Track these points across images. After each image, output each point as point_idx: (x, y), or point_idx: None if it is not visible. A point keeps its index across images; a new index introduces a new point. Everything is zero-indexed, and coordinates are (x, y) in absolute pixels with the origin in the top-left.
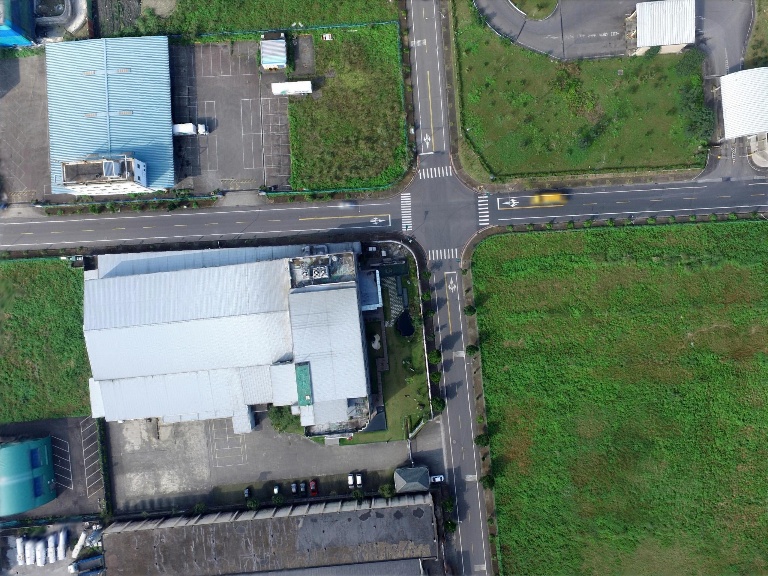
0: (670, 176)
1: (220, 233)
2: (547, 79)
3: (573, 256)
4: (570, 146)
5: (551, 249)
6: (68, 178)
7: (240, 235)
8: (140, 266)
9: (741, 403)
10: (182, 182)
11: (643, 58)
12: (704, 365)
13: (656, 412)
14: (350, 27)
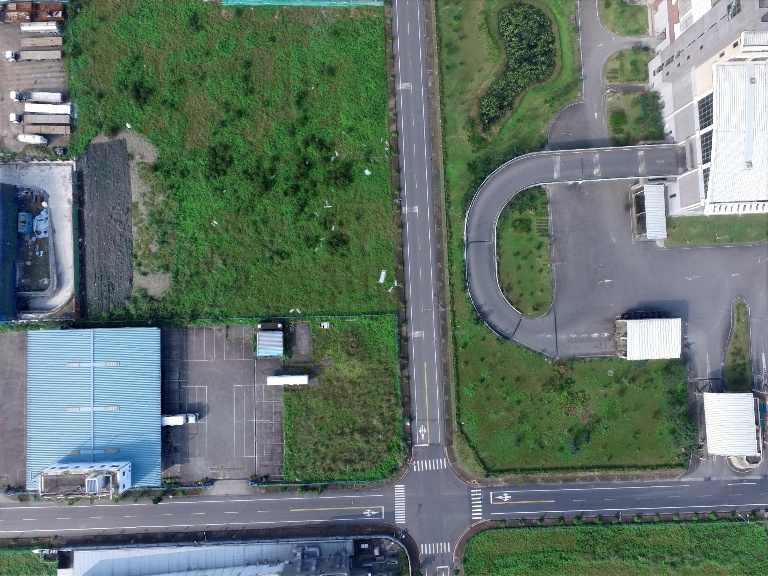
0: (655, 475)
1: (207, 523)
2: (541, 377)
3: (563, 553)
4: (562, 443)
5: (542, 545)
6: (46, 489)
7: (228, 526)
8: (120, 566)
9: None
10: (169, 470)
11: (632, 363)
12: None
13: None
14: (349, 316)
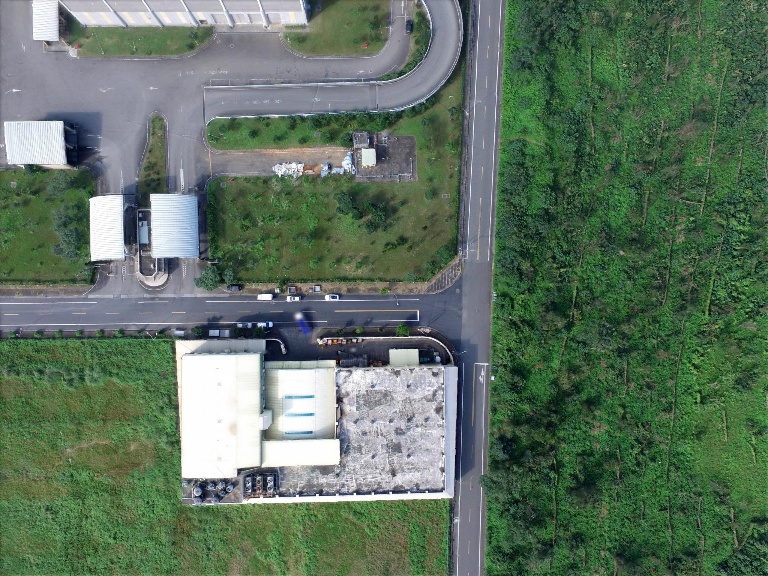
0: (60, 290)
1: None
2: None
3: None
4: None
5: None
6: None
7: None
8: None
9: (115, 521)
10: None
11: None
12: (80, 482)
13: (28, 529)
14: None
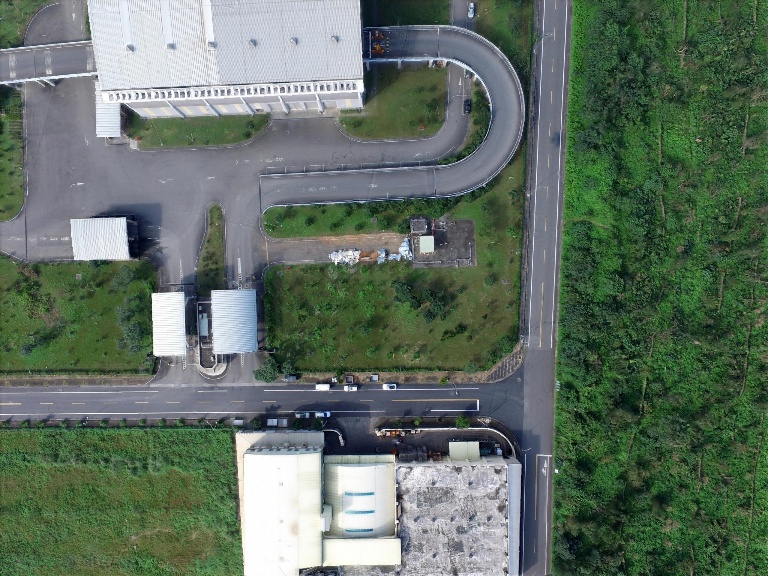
0: (124, 380)
1: None
2: (8, 280)
3: (26, 455)
4: None
5: (6, 447)
6: None
7: None
8: None
9: None
10: None
11: None
12: (144, 569)
13: None
14: None
